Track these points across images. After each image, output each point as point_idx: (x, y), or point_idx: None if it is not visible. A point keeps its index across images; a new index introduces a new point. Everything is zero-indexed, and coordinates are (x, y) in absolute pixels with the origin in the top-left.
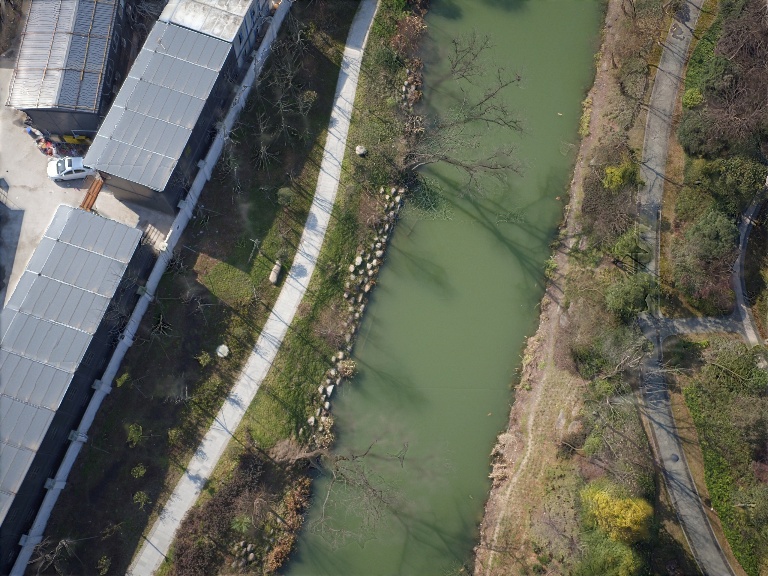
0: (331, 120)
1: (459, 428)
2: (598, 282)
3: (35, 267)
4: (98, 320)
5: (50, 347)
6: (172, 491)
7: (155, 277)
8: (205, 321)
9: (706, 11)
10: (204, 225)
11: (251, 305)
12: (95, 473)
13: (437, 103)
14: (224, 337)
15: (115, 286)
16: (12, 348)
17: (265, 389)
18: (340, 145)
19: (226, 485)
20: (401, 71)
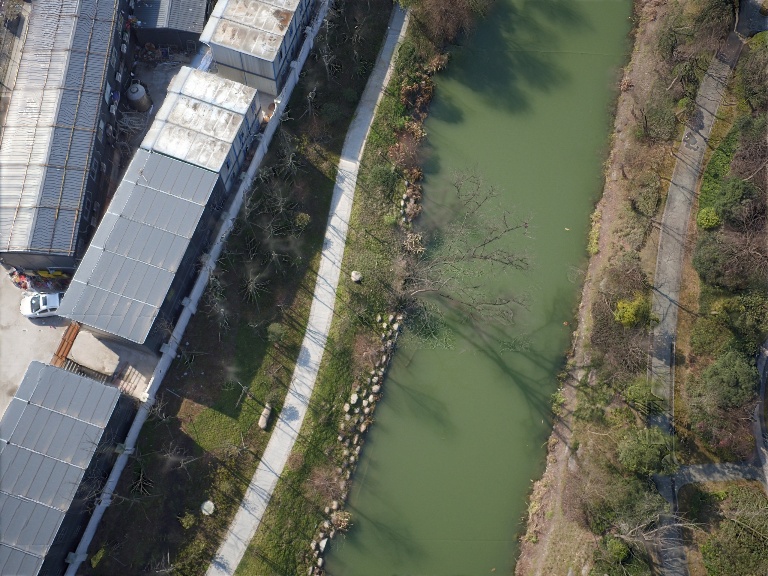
0: (325, 241)
1: None
2: (609, 424)
3: (3, 434)
4: (71, 495)
5: (18, 528)
6: None
7: (135, 429)
8: (189, 476)
9: (721, 118)
10: None
11: (239, 454)
12: None
13: (437, 217)
14: (209, 493)
15: (90, 455)
16: None
17: (253, 550)
18: (334, 270)
19: None
20: (399, 183)
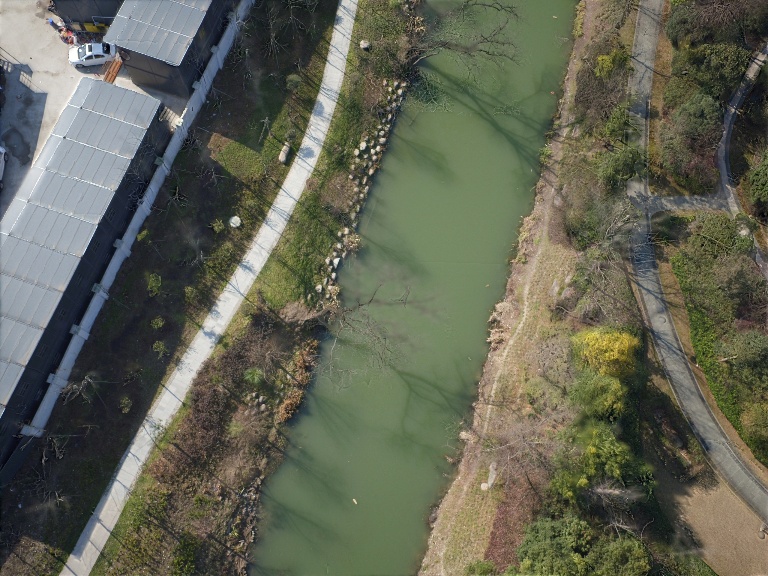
0: (336, 18)
1: (458, 298)
2: (590, 164)
3: (60, 131)
4: (120, 178)
5: (75, 201)
6: (188, 345)
7: (171, 152)
8: (218, 193)
9: None
10: (217, 108)
11: (262, 181)
12: (116, 327)
13: (437, 6)
14: (236, 209)
15: (135, 148)
16: (40, 202)
17: (275, 257)
18: (345, 40)
19: (239, 340)
20: None
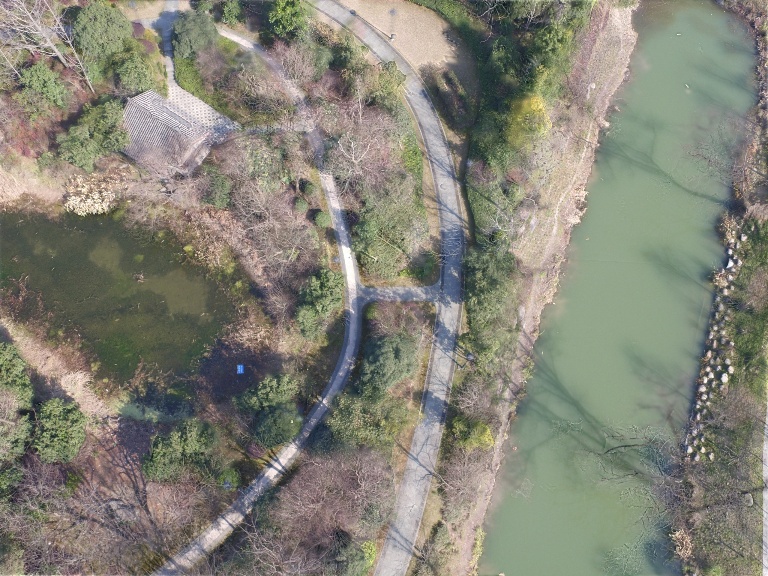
0: None
1: (614, 230)
2: None
3: None
4: None
5: None
6: None
7: None
8: None
9: None
10: None
11: None
12: None
13: None
14: None
15: None
16: None
17: None
18: None
19: None
20: None
